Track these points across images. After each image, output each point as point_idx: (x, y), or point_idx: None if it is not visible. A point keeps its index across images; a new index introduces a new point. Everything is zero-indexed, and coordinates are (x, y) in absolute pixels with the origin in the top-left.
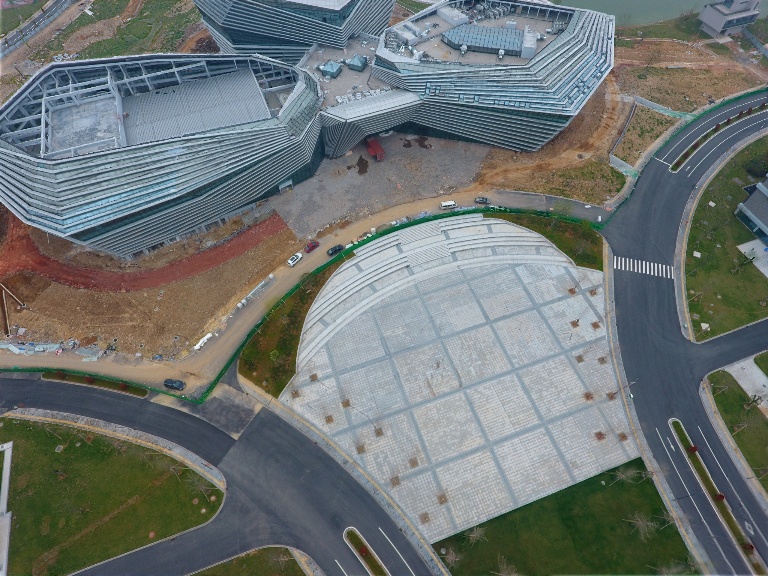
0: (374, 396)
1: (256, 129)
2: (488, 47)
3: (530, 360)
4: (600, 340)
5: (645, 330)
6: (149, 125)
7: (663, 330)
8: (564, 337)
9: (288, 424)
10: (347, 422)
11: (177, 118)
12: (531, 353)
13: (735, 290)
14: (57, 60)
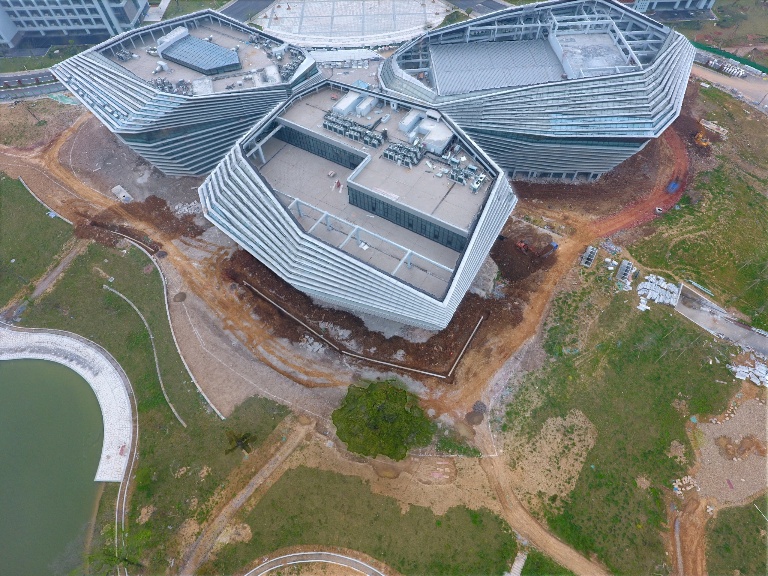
0: (408, 5)
1: (445, 27)
2: (212, 43)
3: (324, 2)
4: (282, 3)
5: (256, 3)
6: (539, 64)
7: (247, 1)
8: (299, 6)
9: (454, 4)
10: (425, 0)
11: (515, 65)
12: (321, 4)
13: (191, 6)
14: (762, 365)
